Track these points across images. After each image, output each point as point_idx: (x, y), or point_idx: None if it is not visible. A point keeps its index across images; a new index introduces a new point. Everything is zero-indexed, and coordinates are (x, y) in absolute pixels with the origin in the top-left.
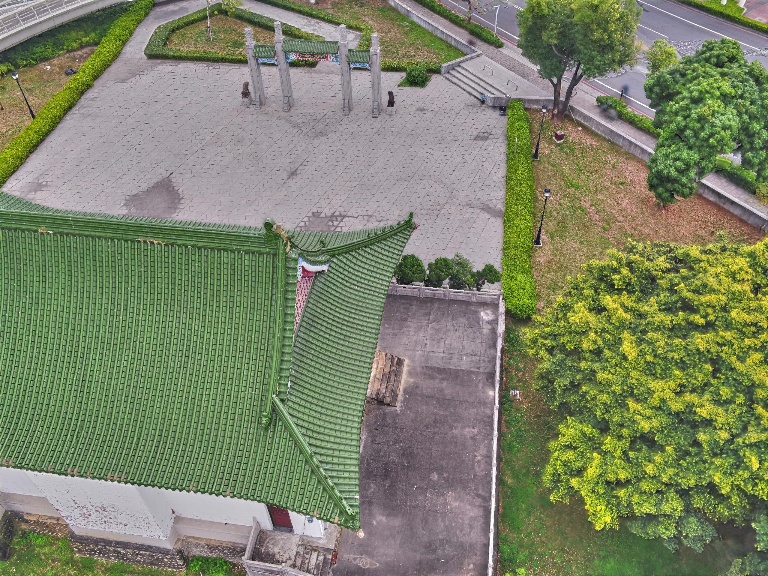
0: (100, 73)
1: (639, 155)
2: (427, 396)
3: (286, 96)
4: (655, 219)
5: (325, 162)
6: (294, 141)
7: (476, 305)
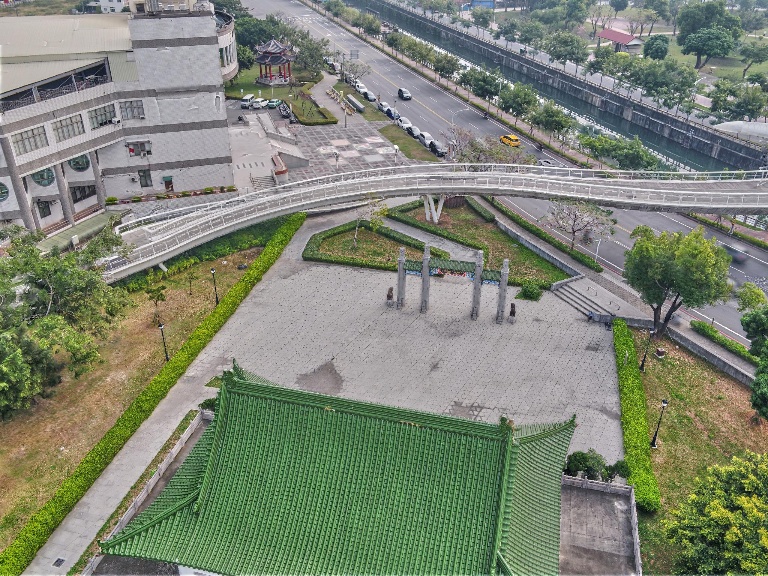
0: (267, 270)
1: (733, 374)
2: (577, 572)
3: (424, 301)
4: (755, 432)
5: (461, 359)
6: (433, 339)
7: (610, 495)
